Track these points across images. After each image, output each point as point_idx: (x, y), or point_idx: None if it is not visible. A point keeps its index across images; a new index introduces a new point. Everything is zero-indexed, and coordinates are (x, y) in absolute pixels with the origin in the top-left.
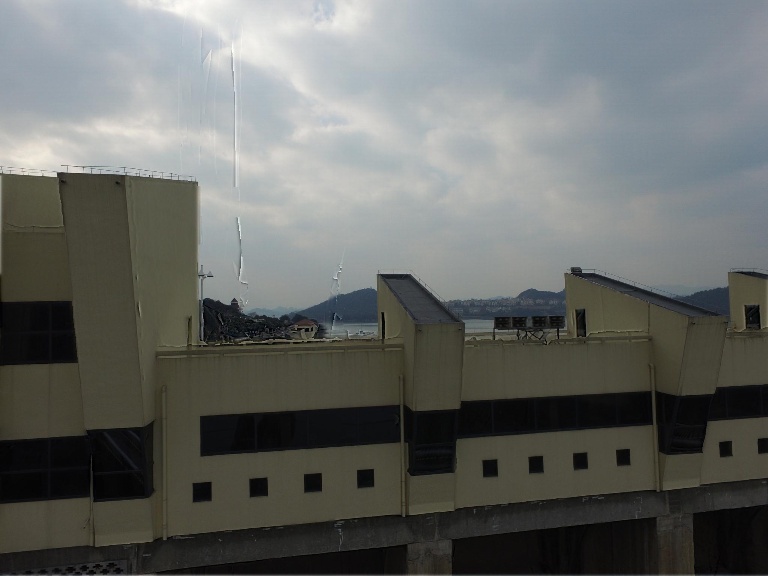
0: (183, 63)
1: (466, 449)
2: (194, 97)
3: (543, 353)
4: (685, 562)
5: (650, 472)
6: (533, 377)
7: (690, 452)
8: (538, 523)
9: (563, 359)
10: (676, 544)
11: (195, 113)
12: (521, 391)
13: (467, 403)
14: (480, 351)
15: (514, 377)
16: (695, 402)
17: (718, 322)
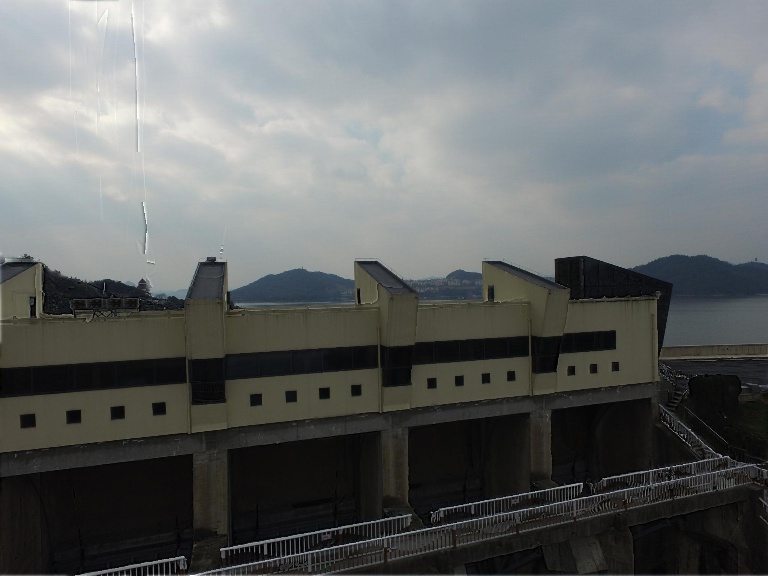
0: (76, 21)
1: (4, 406)
2: (90, 60)
3: (83, 328)
4: (218, 486)
5: (184, 419)
6: (73, 348)
7: (213, 403)
8: (79, 462)
9: (103, 333)
10: (211, 473)
11: (91, 78)
12: (60, 359)
13: (6, 370)
14: (19, 328)
15: (53, 348)
16: (212, 364)
17: (213, 303)
